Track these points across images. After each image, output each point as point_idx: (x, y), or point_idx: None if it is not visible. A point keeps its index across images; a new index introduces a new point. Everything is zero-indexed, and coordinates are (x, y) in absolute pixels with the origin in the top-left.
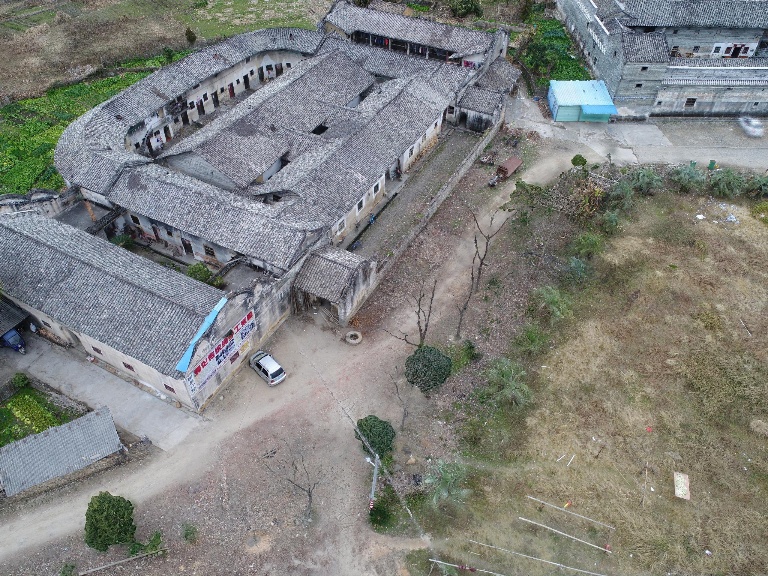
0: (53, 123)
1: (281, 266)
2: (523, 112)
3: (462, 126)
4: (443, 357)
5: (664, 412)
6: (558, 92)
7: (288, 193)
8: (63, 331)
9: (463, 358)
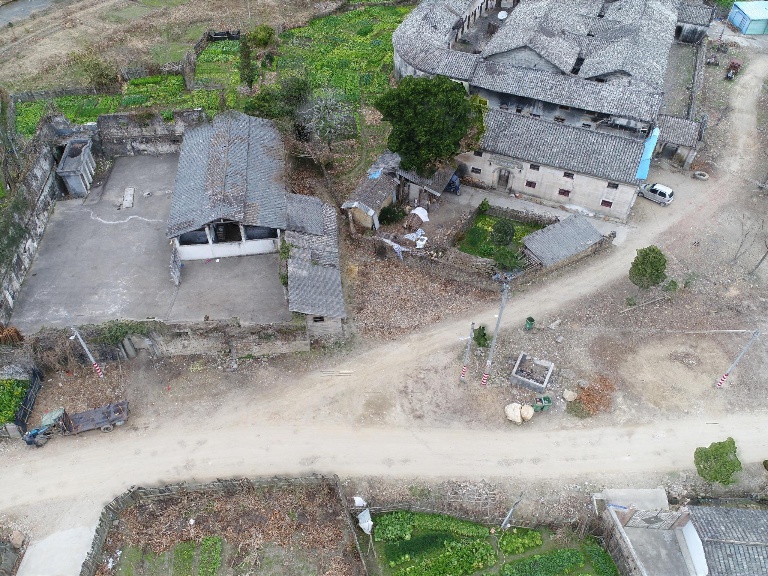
0: (333, 45)
1: None
2: (714, 29)
3: (674, 39)
4: None
5: None
6: (746, 10)
7: (614, 75)
8: (494, 174)
9: None
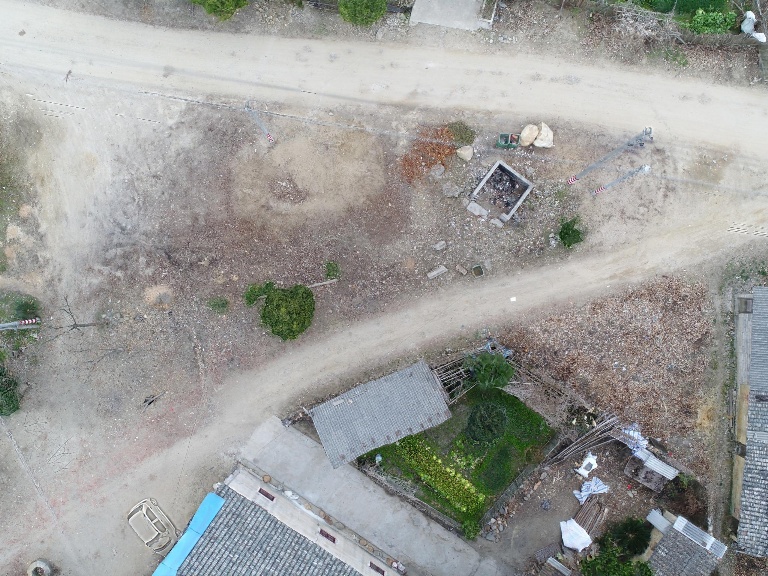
0: None
1: None
2: None
3: None
4: None
5: None
6: None
7: None
8: None
9: None
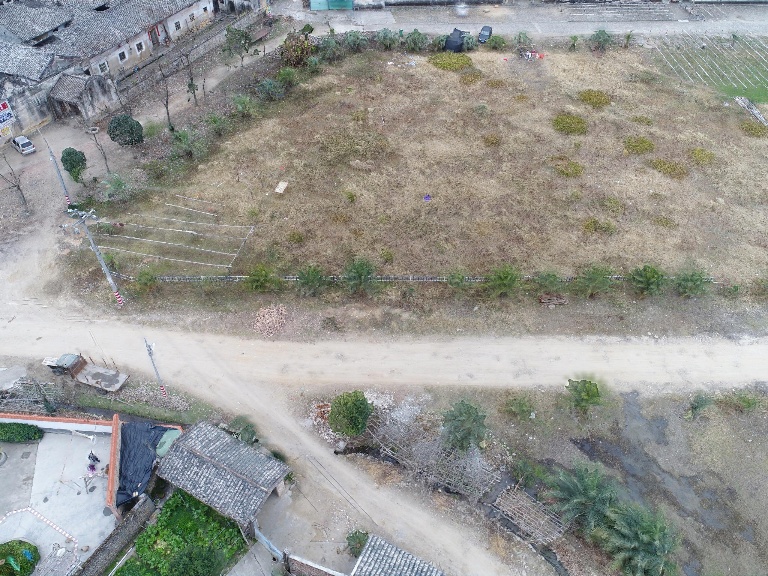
0: None
1: (35, 78)
2: (288, 5)
3: (233, 14)
4: (131, 119)
5: (297, 160)
6: None
7: (56, 40)
8: None
9: (171, 140)
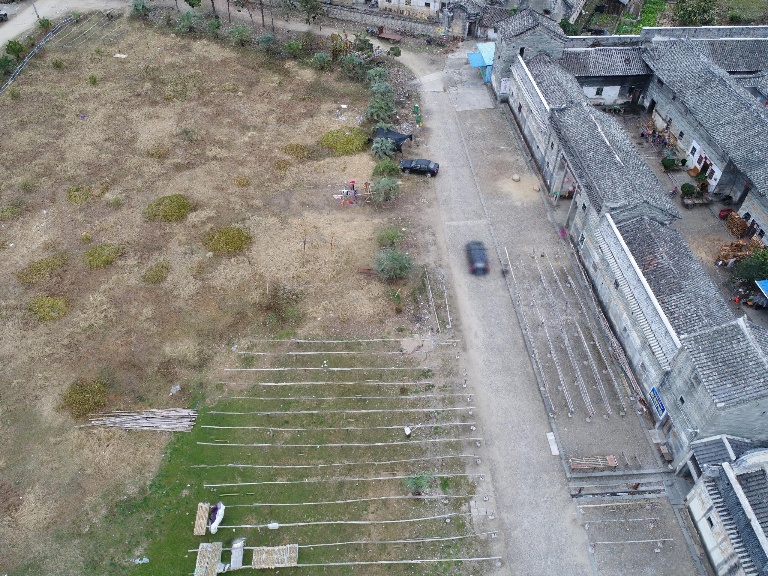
0: None
1: None
2: None
3: None
4: None
5: None
6: None
7: None
8: None
9: None
